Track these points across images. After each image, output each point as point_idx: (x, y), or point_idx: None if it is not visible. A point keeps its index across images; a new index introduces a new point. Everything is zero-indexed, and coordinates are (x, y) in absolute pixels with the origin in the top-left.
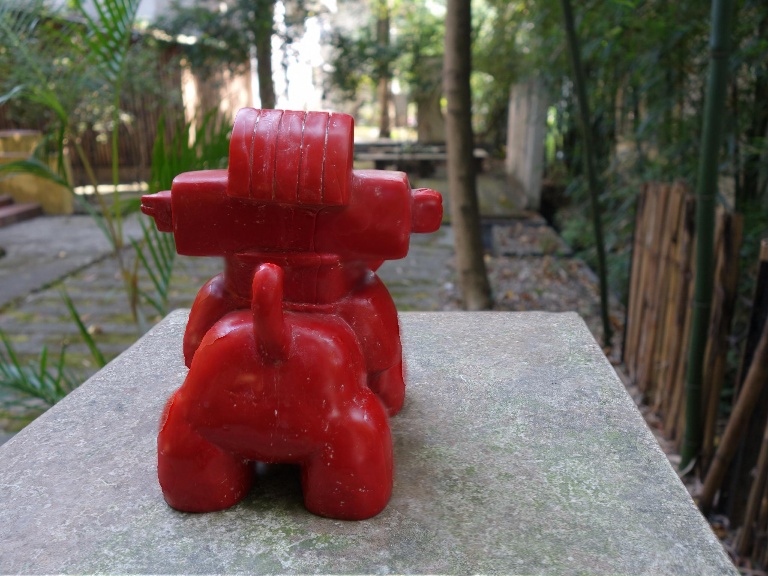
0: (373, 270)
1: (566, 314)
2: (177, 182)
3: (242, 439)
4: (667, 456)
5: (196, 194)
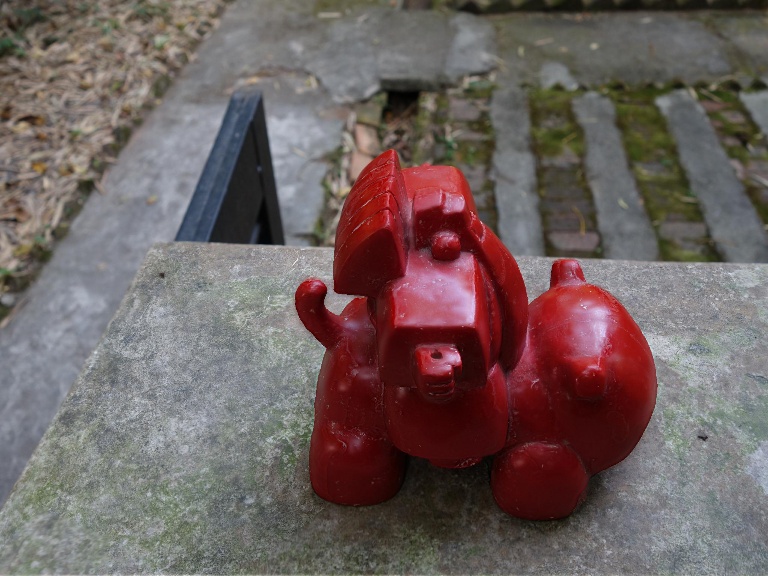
0: None
1: None
2: None
3: None
4: None
5: None
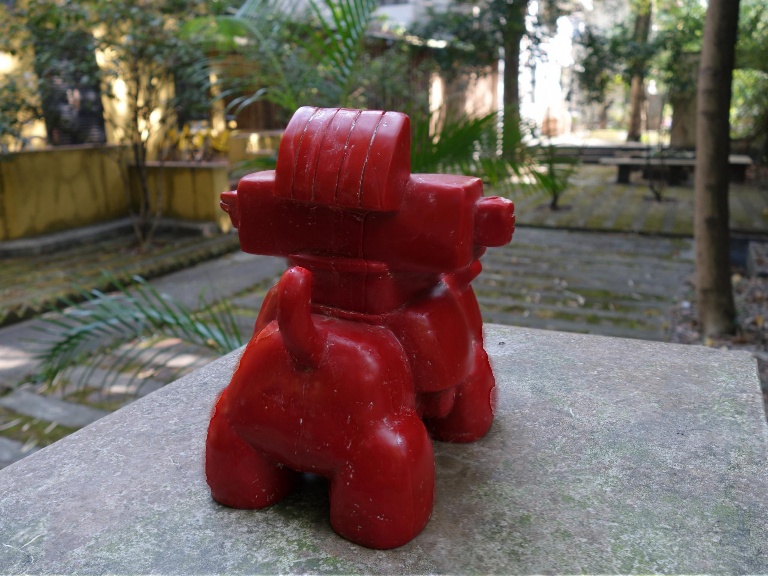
0: (434, 283)
1: (736, 353)
2: (244, 180)
3: (273, 442)
4: None
5: (257, 193)
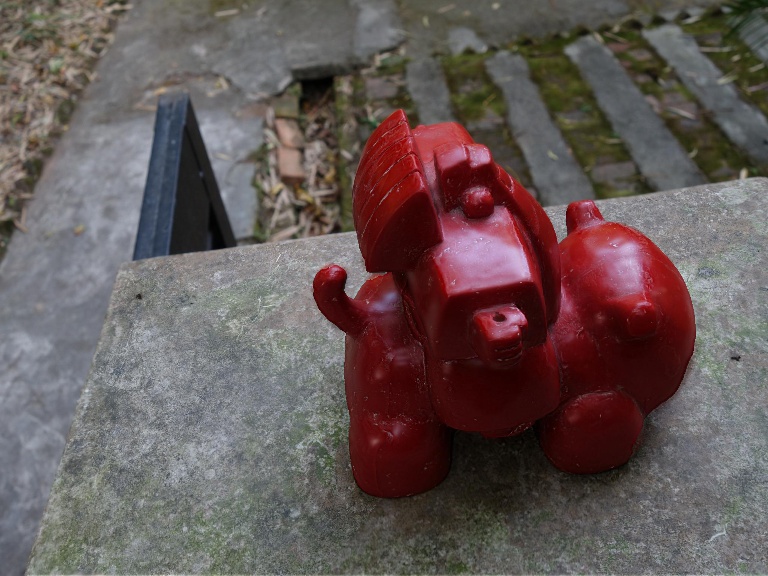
0: None
1: None
2: None
3: None
4: None
5: None
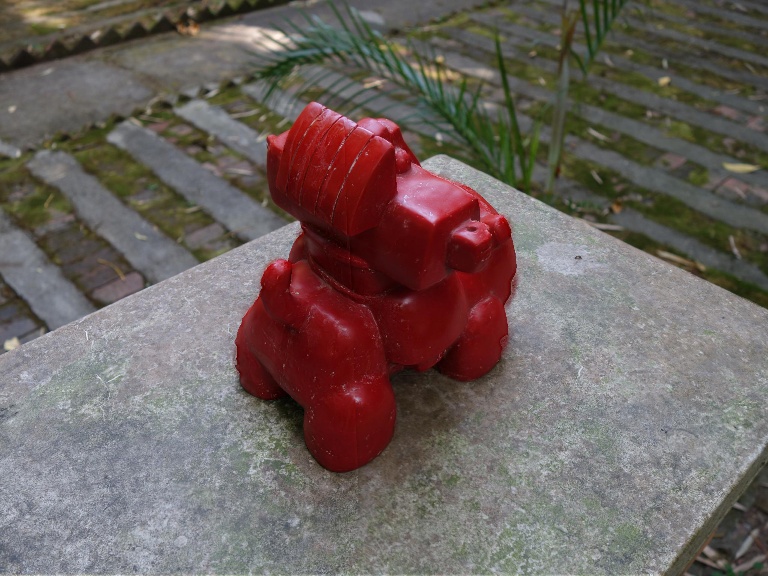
0: None
1: None
2: (273, 143)
3: (271, 366)
4: None
5: (279, 162)
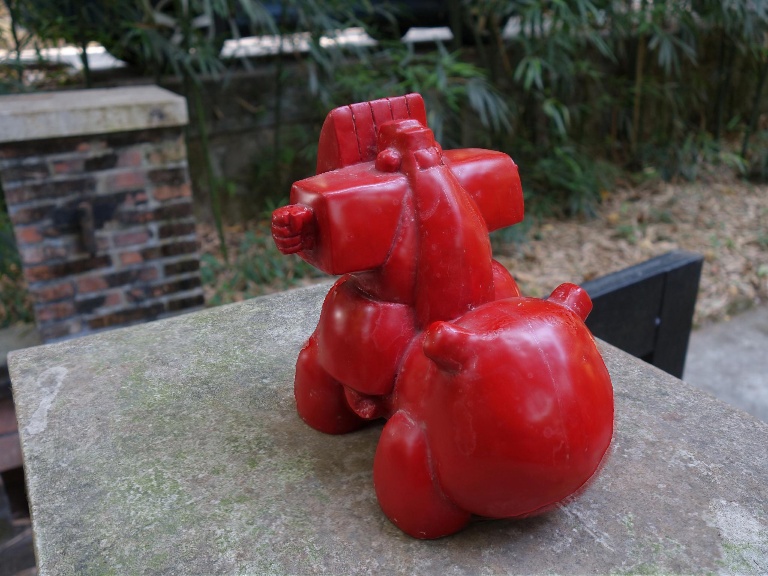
0: None
1: None
2: None
3: None
4: (39, 572)
5: None
